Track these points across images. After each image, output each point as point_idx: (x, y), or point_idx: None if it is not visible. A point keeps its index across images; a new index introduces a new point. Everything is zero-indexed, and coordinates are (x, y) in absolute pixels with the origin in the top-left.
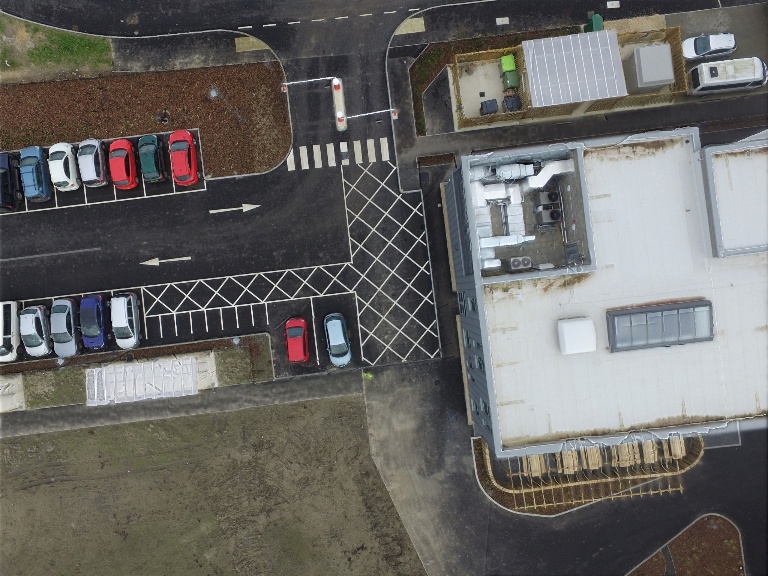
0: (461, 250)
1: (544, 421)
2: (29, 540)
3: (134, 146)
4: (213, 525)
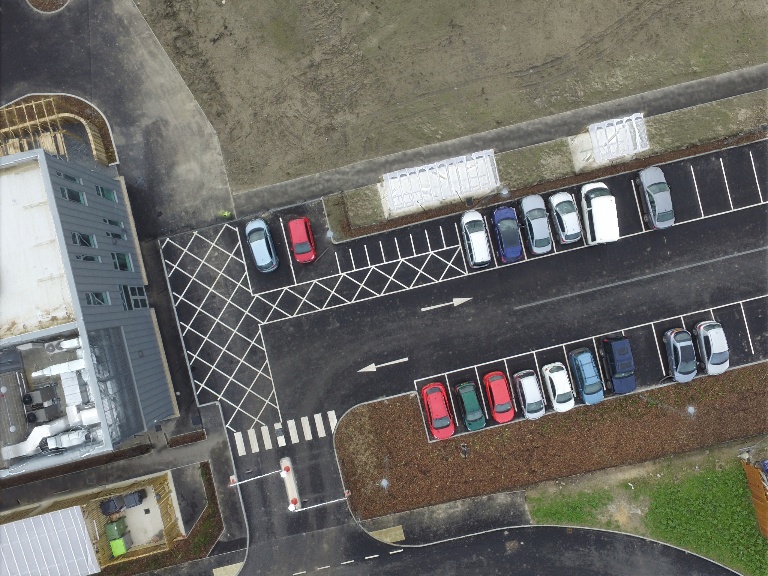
0: (128, 352)
1: (2, 190)
2: (547, 8)
3: (492, 417)
4: (365, 45)
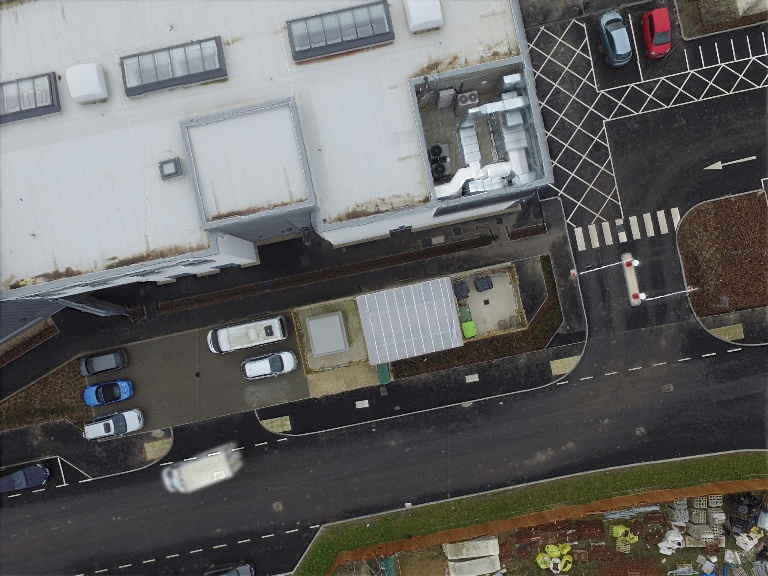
0: None
1: None
2: None
3: None
4: None
